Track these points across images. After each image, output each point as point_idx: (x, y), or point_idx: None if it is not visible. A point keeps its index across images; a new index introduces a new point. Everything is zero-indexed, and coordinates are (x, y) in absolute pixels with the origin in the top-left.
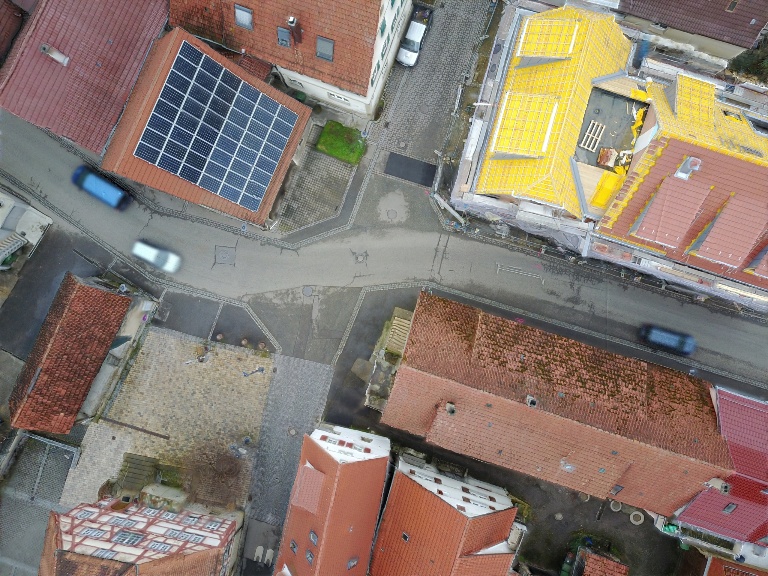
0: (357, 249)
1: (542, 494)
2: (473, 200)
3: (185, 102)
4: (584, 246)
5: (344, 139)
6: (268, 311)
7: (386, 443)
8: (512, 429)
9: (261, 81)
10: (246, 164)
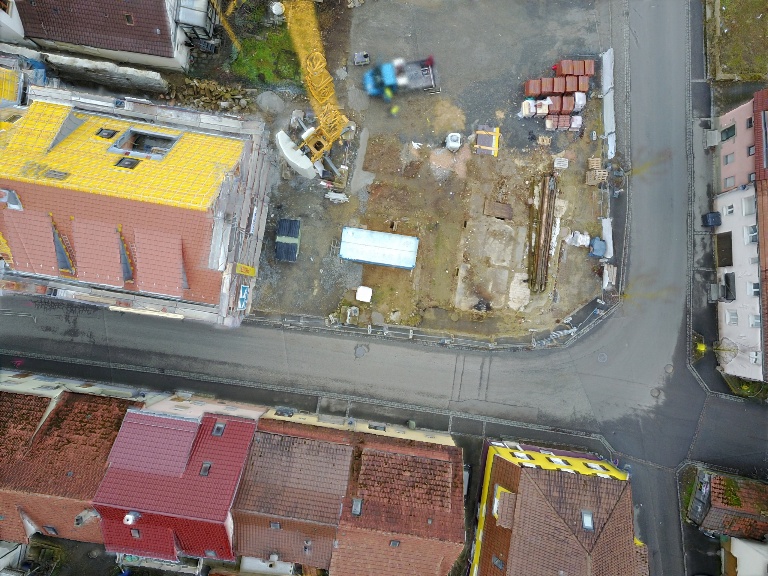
0: None
1: None
2: None
3: None
4: None
5: None
6: None
7: None
8: None
9: None
10: None
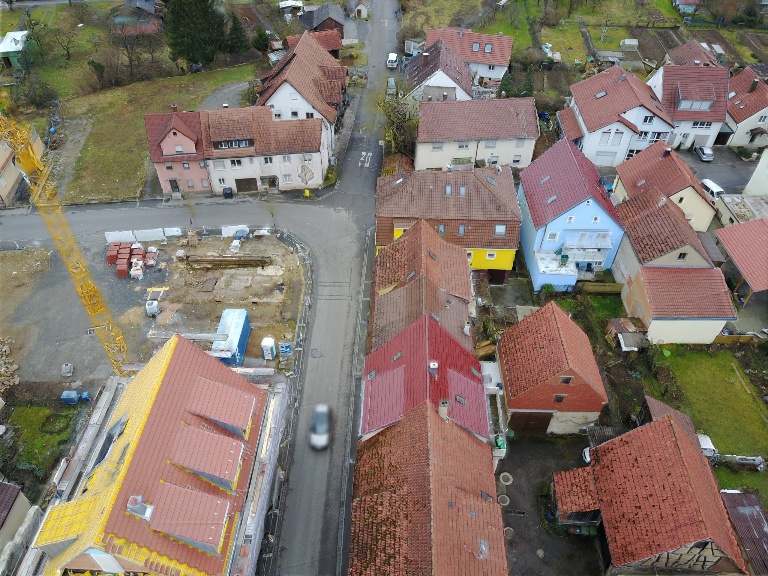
0: None
1: None
2: None
3: None
4: None
5: None
6: None
7: None
8: None
9: None
10: None
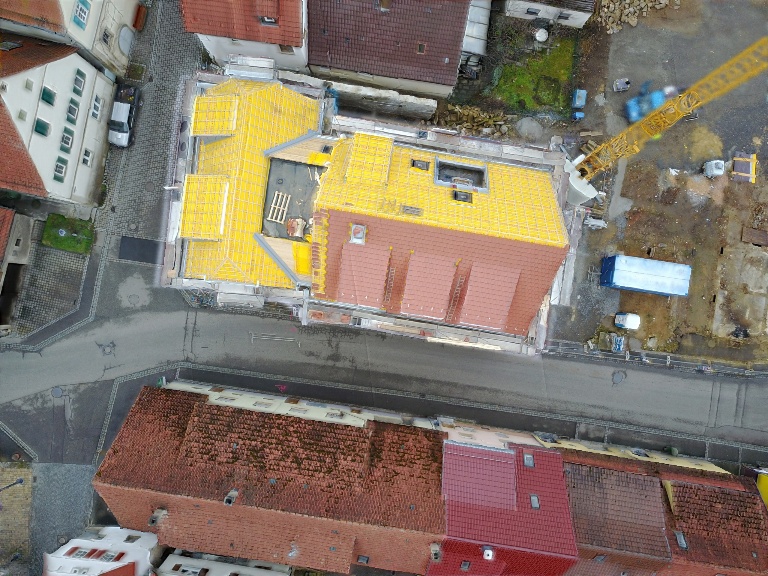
0: (103, 341)
1: None
2: (183, 285)
3: None
4: (303, 314)
5: (69, 231)
6: (18, 420)
7: (155, 538)
8: (232, 523)
9: None
10: None
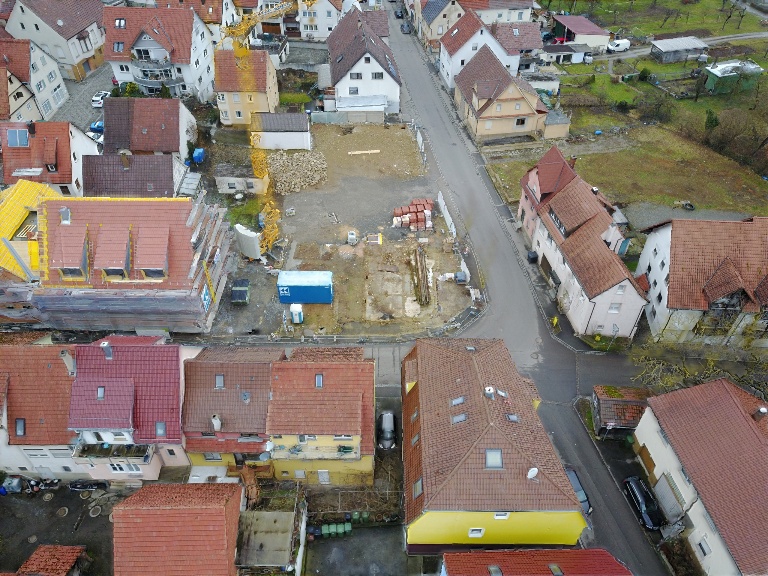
0: None
1: (17, 522)
2: None
3: None
4: (30, 295)
5: None
6: None
7: None
8: None
9: None
10: None
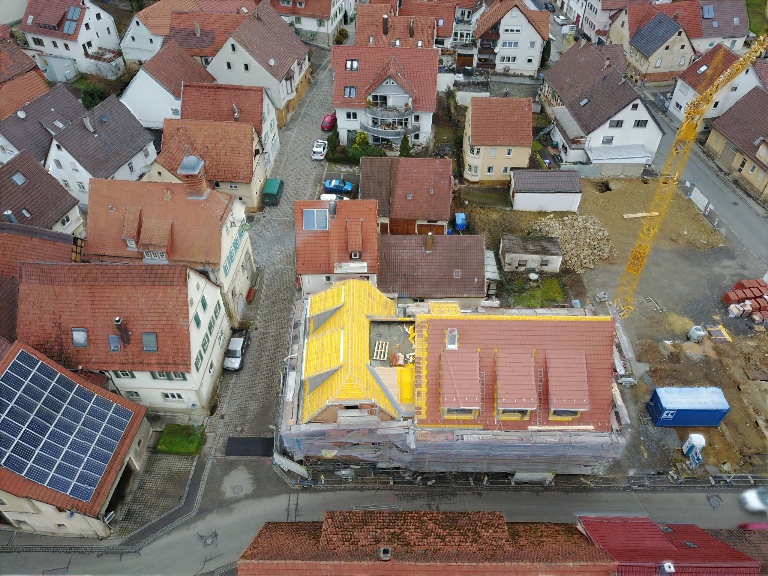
0: (205, 532)
1: None
2: (300, 429)
3: (17, 398)
4: (410, 440)
5: (183, 435)
6: None
7: None
8: None
9: (96, 386)
10: (78, 455)
